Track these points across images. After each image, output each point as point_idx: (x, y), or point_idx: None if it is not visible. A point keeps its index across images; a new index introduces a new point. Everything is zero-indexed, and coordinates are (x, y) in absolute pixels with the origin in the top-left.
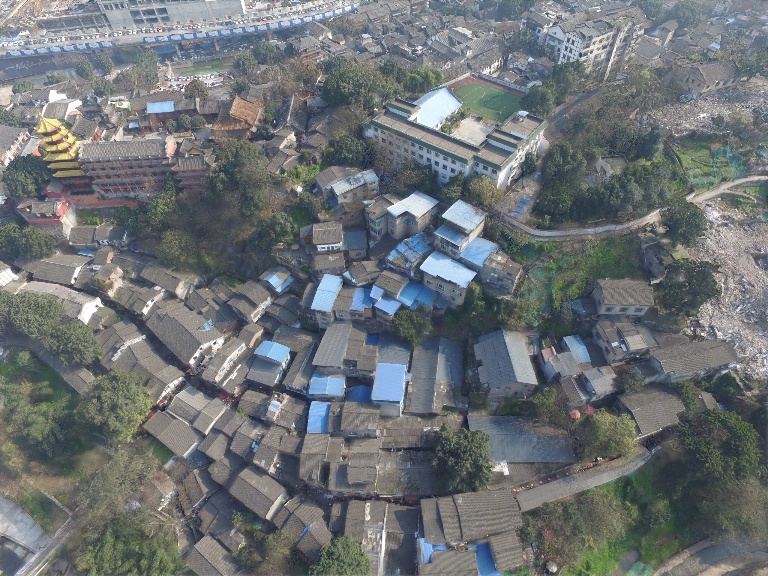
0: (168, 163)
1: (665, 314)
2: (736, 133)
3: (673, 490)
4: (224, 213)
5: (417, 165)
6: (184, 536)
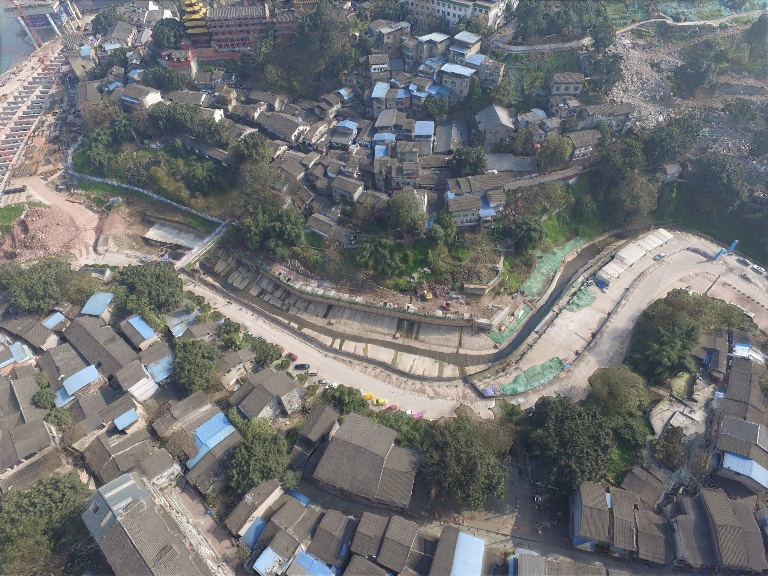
0: (266, 22)
1: (593, 95)
2: None
3: (597, 193)
4: (309, 48)
5: None
6: None
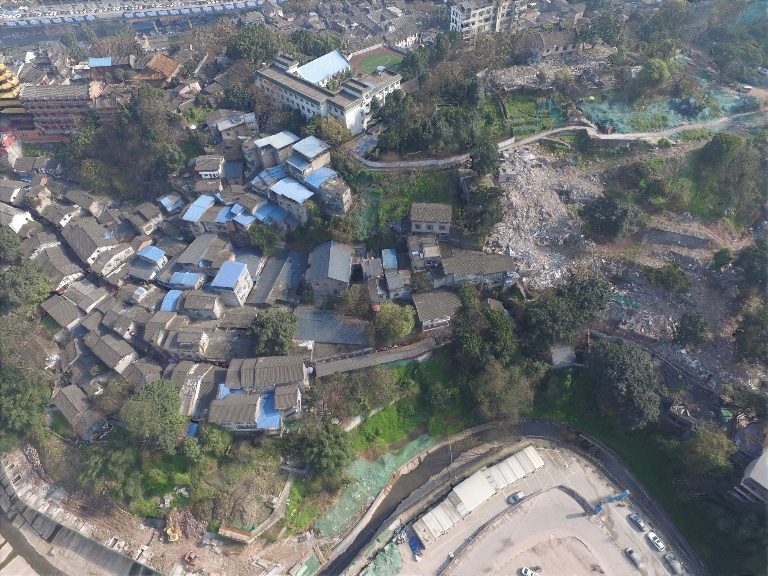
0: None
1: (469, 234)
2: (561, 89)
3: (457, 376)
4: None
5: (290, 110)
6: (60, 387)
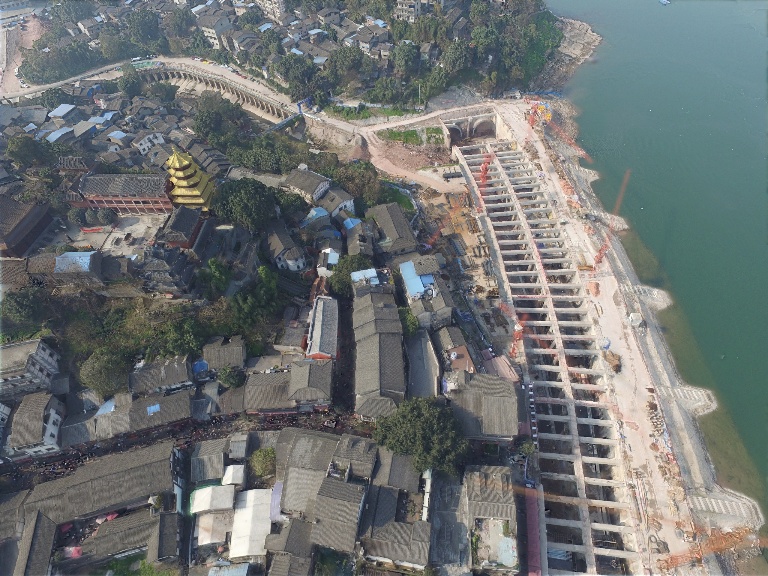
0: None
1: None
2: None
3: None
4: None
5: None
6: None
